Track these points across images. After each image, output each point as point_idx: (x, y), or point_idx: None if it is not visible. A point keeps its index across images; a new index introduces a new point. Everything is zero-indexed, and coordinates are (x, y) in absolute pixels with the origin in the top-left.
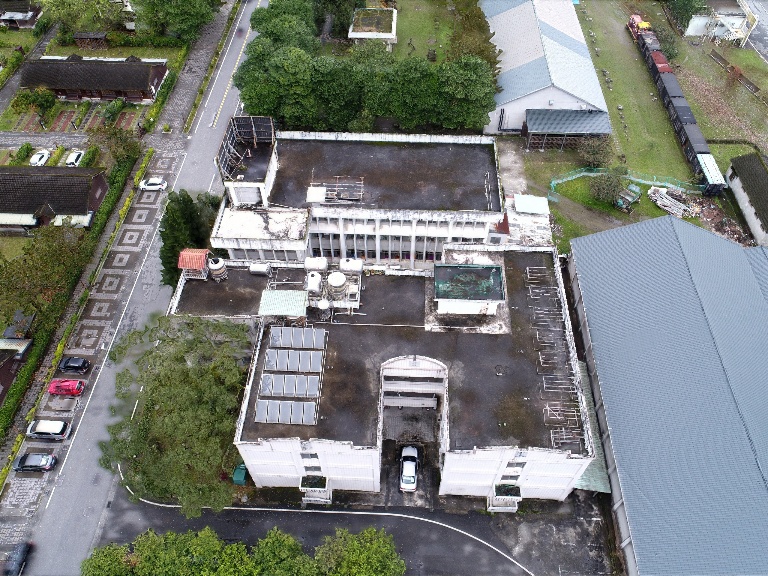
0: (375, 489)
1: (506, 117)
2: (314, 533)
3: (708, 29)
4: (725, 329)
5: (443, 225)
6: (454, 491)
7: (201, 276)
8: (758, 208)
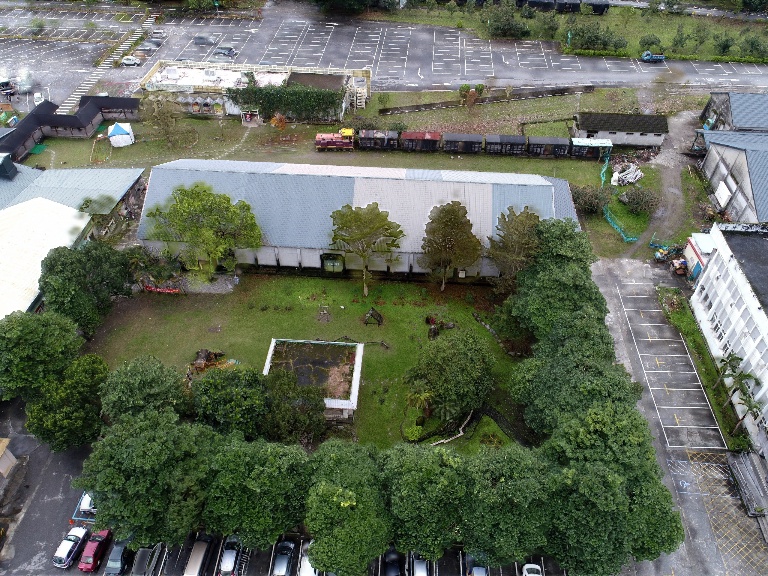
0: None
1: None
2: None
3: (354, 102)
4: None
5: None
6: None
7: None
8: (642, 130)
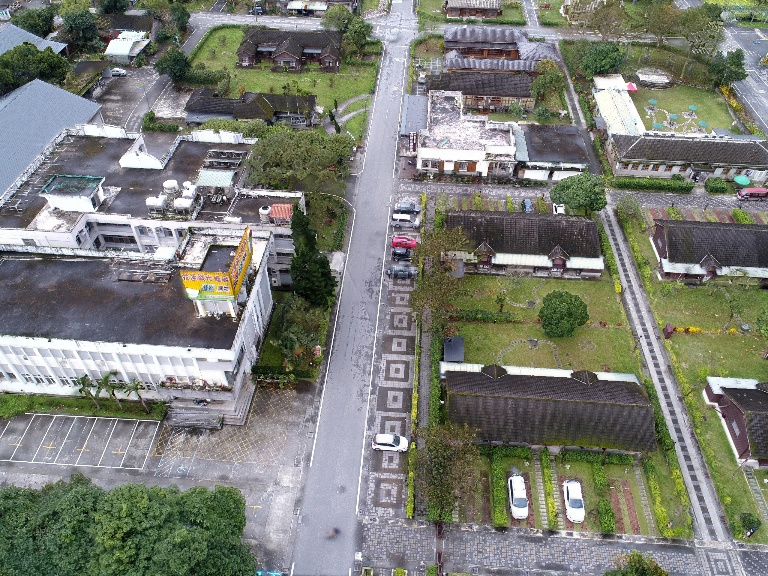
0: None
1: None
2: None
3: None
4: None
5: None
6: None
7: None
8: None
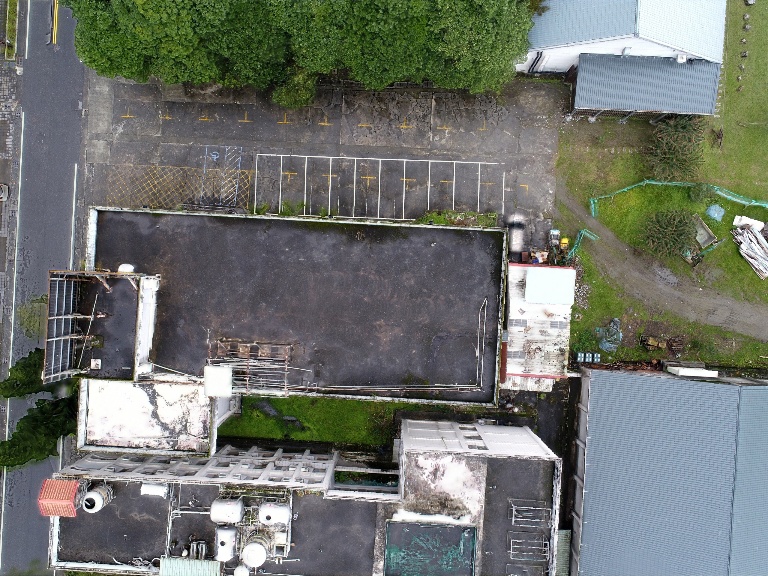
0: None
1: (544, 60)
2: None
3: None
4: (747, 575)
5: None
6: None
7: None
8: None
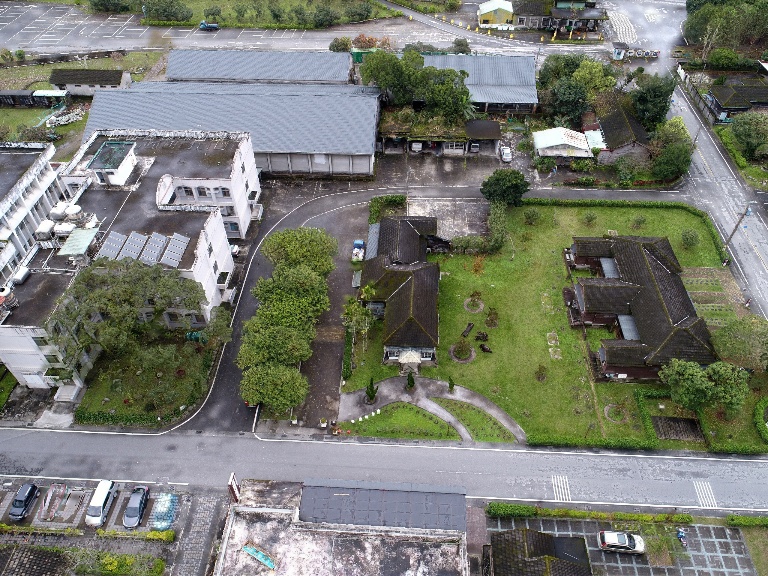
0: (233, 264)
1: None
2: (254, 298)
3: None
4: None
5: (32, 189)
6: (244, 229)
7: (5, 314)
8: (99, 82)
